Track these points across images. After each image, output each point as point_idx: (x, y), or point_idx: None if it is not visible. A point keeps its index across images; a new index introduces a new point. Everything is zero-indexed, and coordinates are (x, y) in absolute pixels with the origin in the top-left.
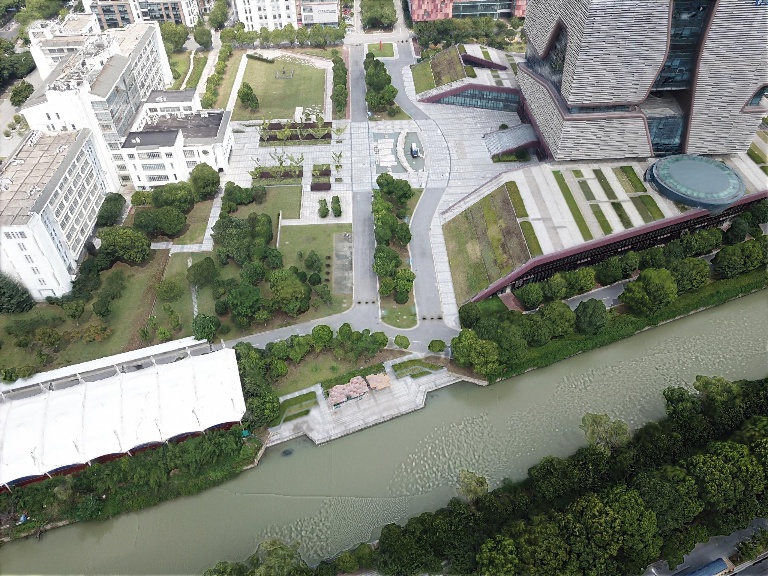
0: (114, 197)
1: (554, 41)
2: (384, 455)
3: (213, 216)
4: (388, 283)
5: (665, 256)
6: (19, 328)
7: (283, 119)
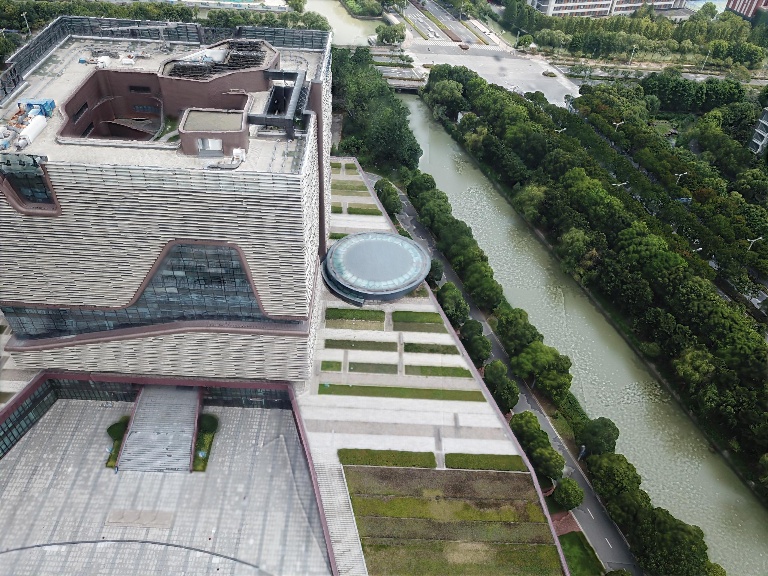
0: None
1: (155, 273)
2: None
3: None
4: None
5: None
6: None
7: None
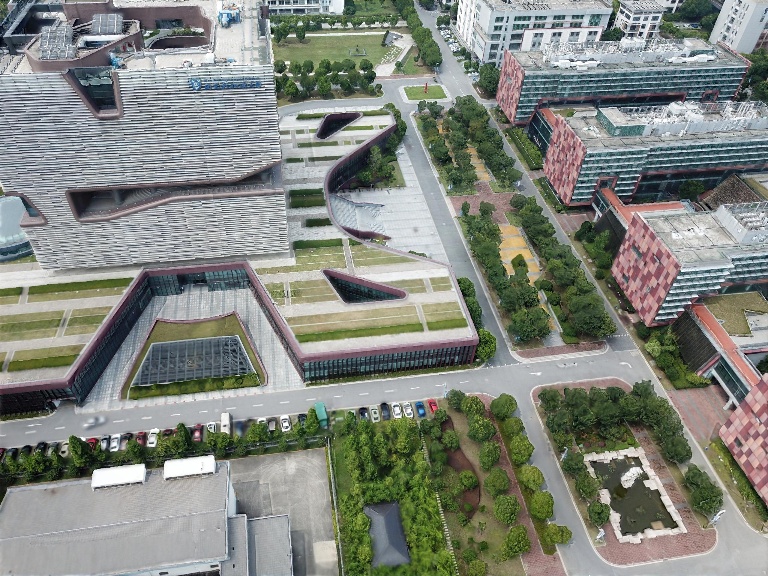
0: None
1: None
2: None
3: None
4: None
5: None
6: None
7: None
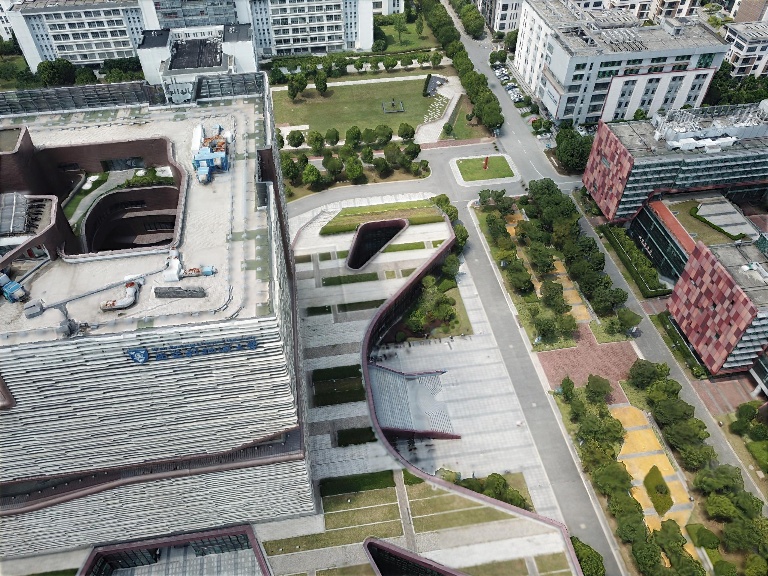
0: (130, 59)
1: None
2: None
3: None
4: None
5: None
6: (4, 66)
7: None
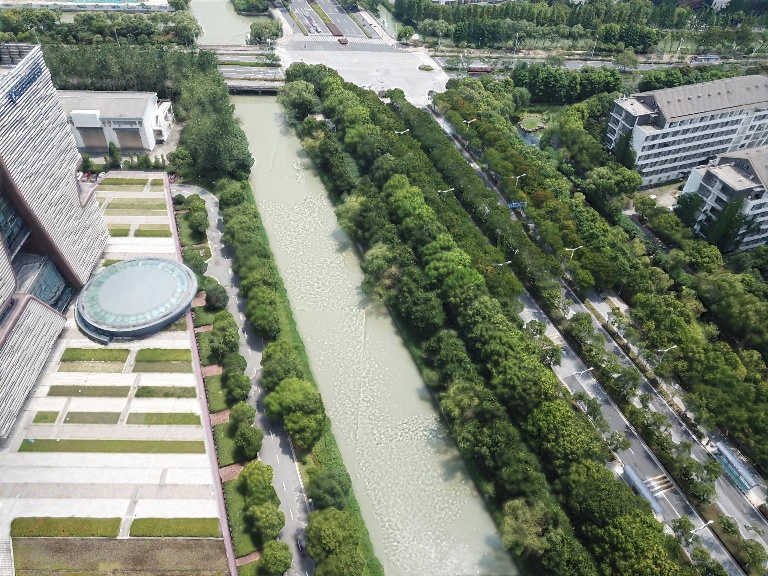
0: None
1: None
2: None
3: None
4: None
5: None
6: None
7: None
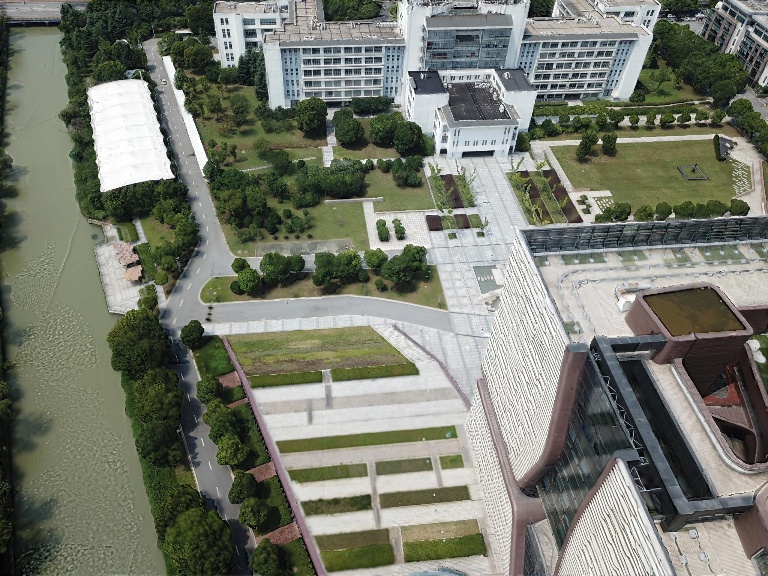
0: (380, 99)
1: None
2: (77, 293)
3: (375, 161)
4: (235, 262)
5: (265, 572)
6: None
7: (569, 181)
